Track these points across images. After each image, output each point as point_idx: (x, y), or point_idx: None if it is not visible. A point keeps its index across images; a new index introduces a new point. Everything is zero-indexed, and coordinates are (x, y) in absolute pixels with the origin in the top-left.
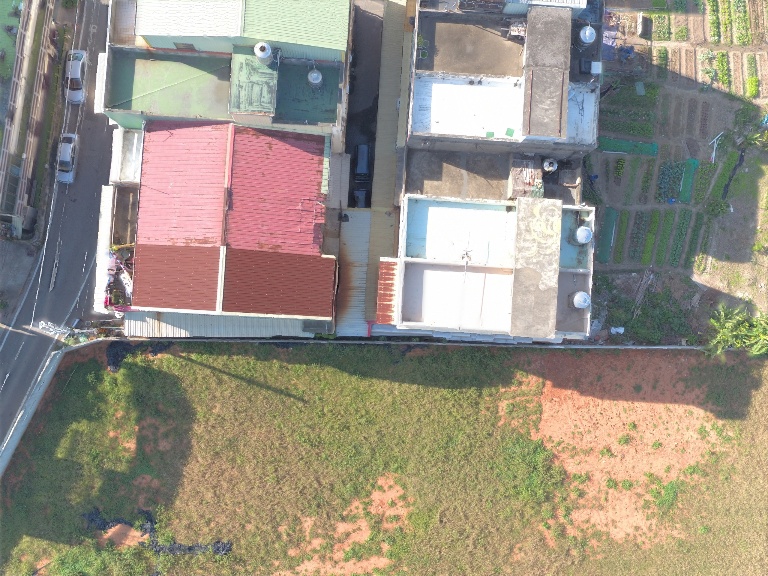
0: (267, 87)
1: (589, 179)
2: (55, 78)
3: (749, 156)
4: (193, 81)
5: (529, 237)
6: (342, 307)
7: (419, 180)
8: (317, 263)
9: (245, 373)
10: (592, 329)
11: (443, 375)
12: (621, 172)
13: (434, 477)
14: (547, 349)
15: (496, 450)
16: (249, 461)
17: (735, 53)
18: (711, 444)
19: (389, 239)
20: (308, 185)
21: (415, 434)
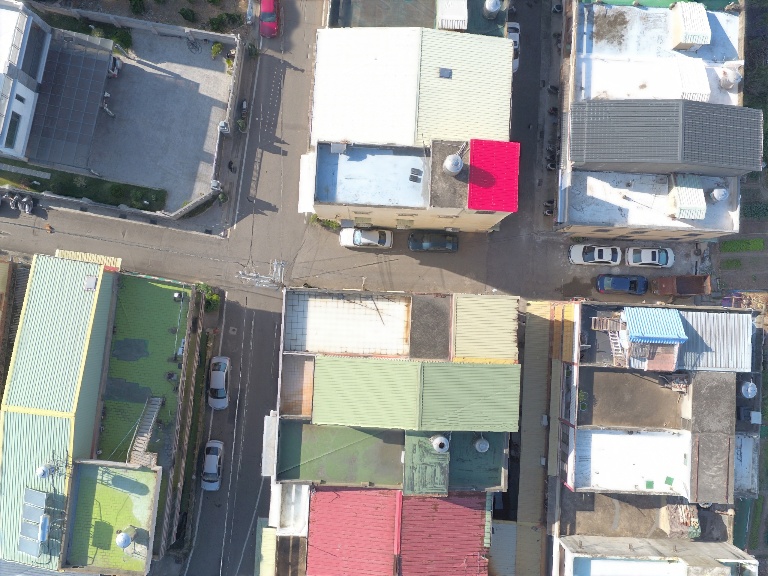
0: (440, 468)
1: None
2: (200, 389)
3: None
4: (359, 445)
5: None
6: None
7: (571, 510)
8: None
9: None
10: None
11: None
12: None
13: None
14: None
15: None
16: None
17: None
18: None
19: (536, 554)
20: (472, 540)
21: None
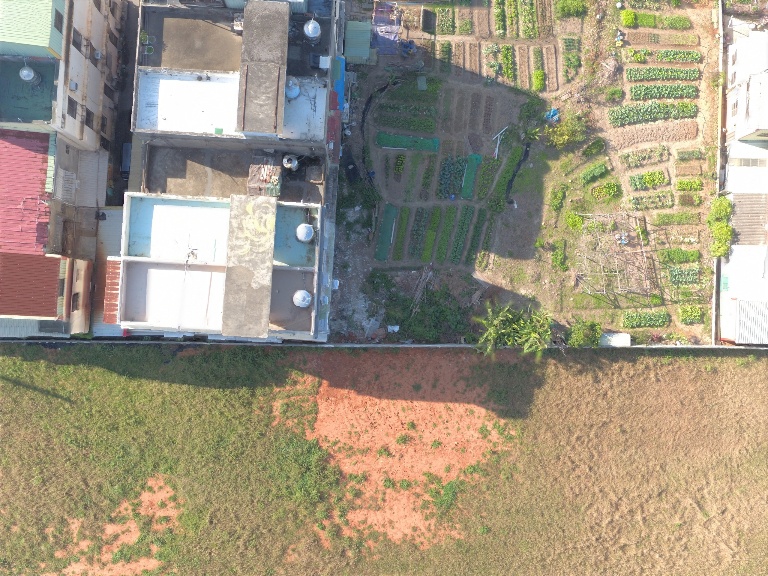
0: None
1: (368, 175)
2: None
3: (534, 151)
4: None
5: (241, 235)
6: (98, 307)
7: (162, 178)
8: (40, 262)
9: (11, 374)
10: (369, 327)
11: (214, 375)
12: (401, 168)
13: (204, 478)
14: (324, 348)
15: (269, 450)
16: (14, 462)
17: (521, 46)
18: (493, 443)
19: None
20: (31, 183)
21: (185, 434)
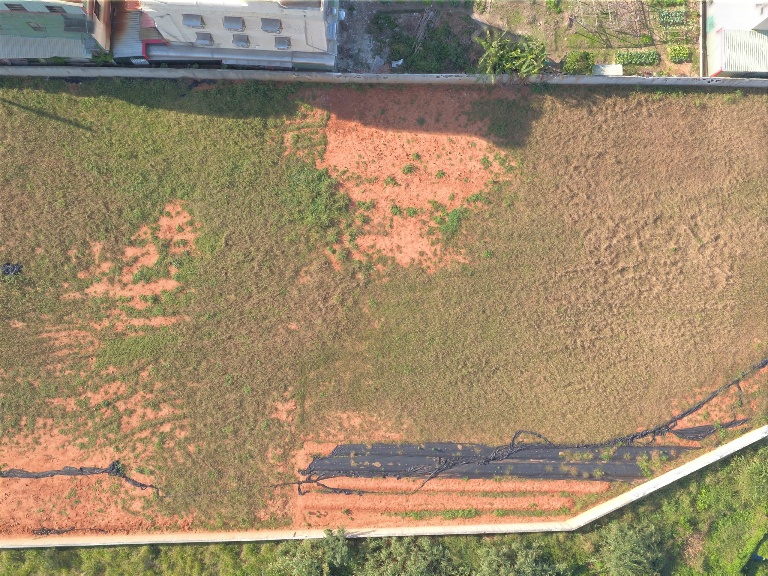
0: None
1: None
2: None
3: None
4: None
5: None
6: (118, 29)
7: None
8: None
9: (35, 105)
10: (374, 64)
11: (228, 107)
12: None
13: (220, 202)
14: (331, 84)
15: (281, 178)
16: (38, 187)
17: None
18: (494, 174)
19: None
20: None
21: (201, 162)
